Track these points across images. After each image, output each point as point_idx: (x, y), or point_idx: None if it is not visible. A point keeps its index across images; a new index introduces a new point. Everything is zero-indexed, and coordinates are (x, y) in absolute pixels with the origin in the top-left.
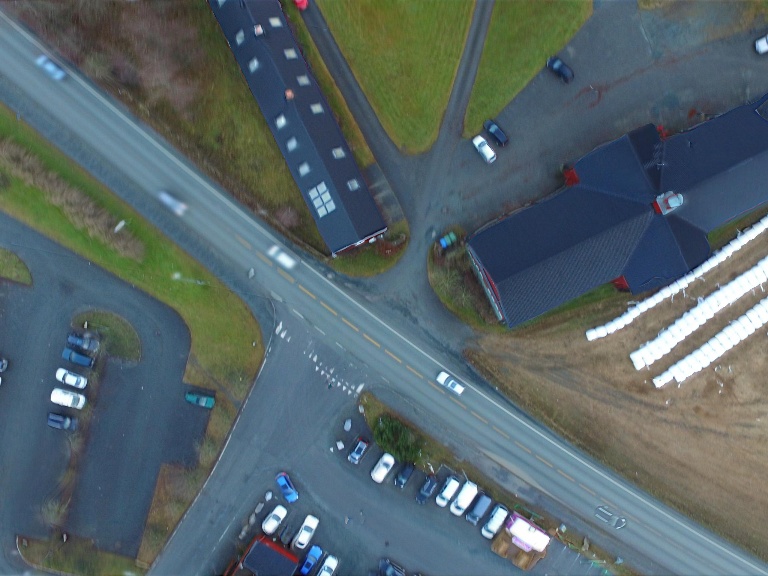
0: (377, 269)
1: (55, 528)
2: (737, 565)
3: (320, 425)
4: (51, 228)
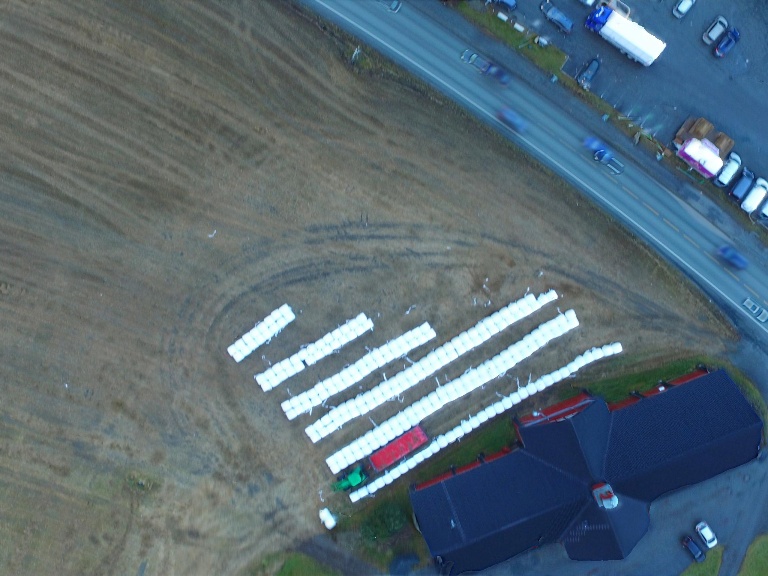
0: None
1: None
2: (484, 101)
3: None
4: None
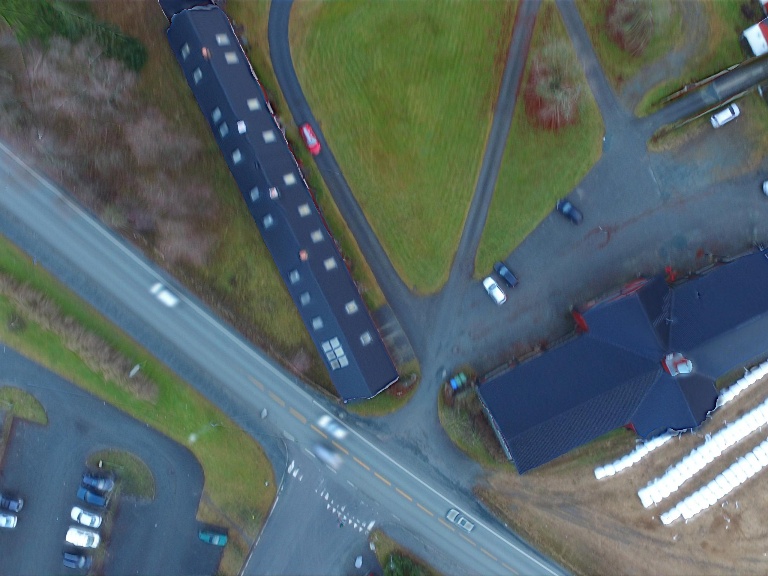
0: (388, 408)
1: None
2: None
3: (331, 562)
4: (67, 369)
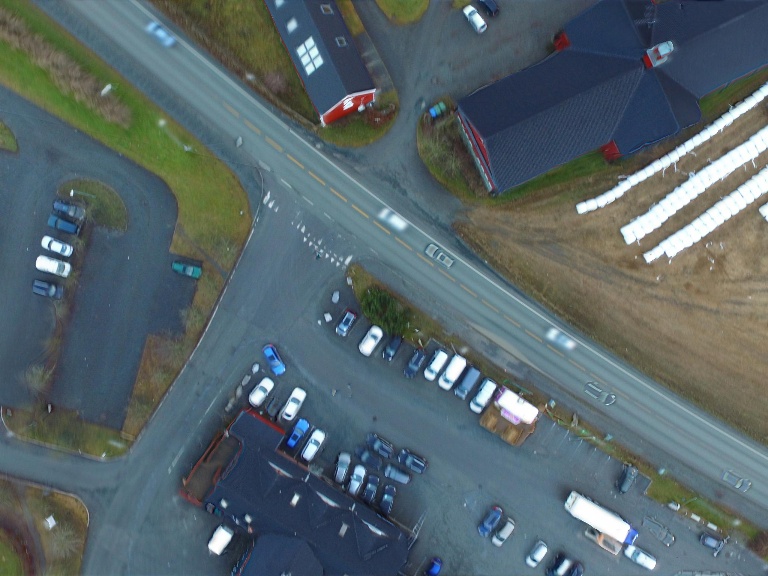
0: (366, 139)
1: (40, 398)
2: (727, 443)
3: (308, 297)
4: (37, 94)
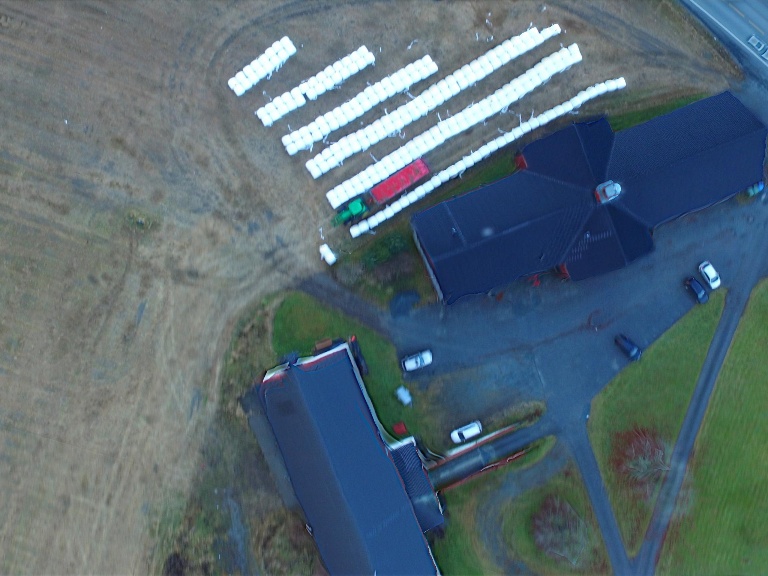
0: None
1: None
2: None
3: None
4: None
